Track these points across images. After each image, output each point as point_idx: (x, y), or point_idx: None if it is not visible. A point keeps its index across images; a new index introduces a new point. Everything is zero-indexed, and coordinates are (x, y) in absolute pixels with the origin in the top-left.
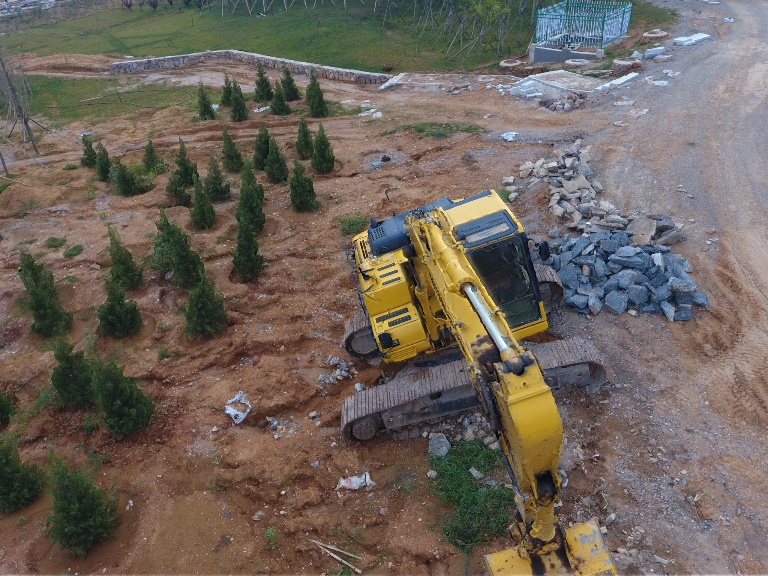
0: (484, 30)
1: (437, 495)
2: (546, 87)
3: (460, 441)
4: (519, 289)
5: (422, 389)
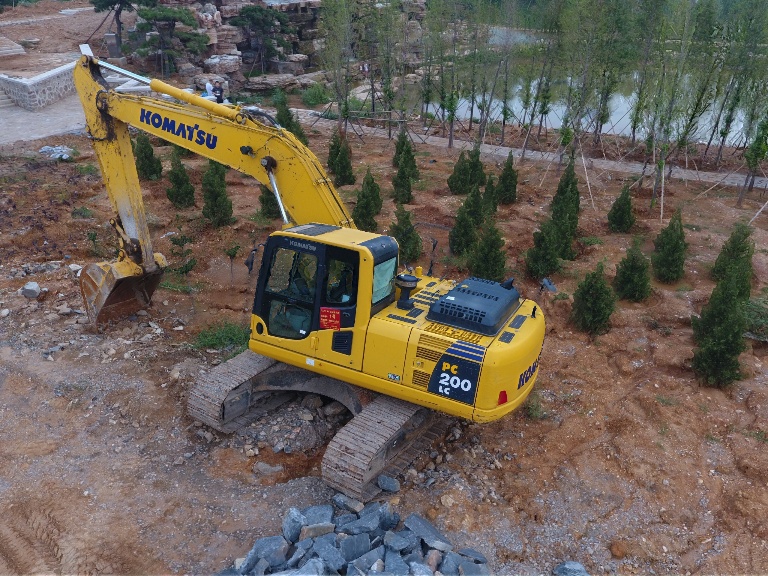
0: None
1: None
2: None
3: None
4: None
5: None
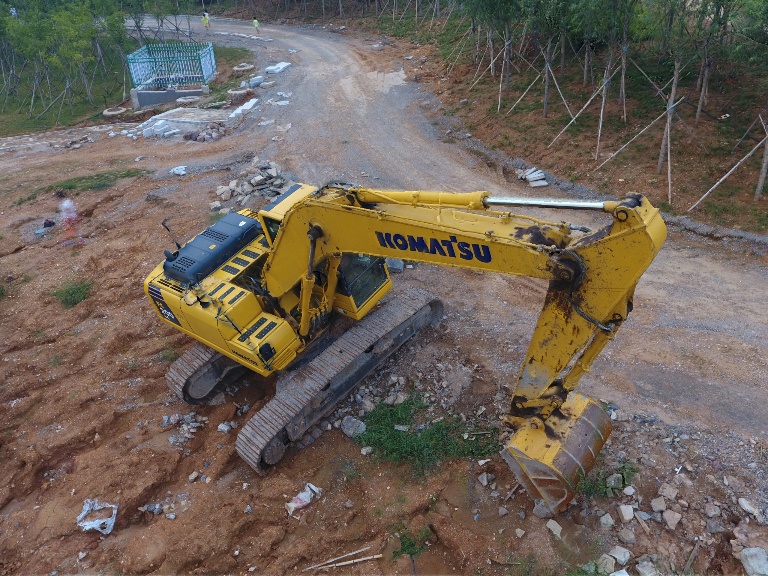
0: (70, 82)
1: (392, 458)
2: (177, 124)
3: (365, 415)
4: (356, 263)
5: (318, 383)
